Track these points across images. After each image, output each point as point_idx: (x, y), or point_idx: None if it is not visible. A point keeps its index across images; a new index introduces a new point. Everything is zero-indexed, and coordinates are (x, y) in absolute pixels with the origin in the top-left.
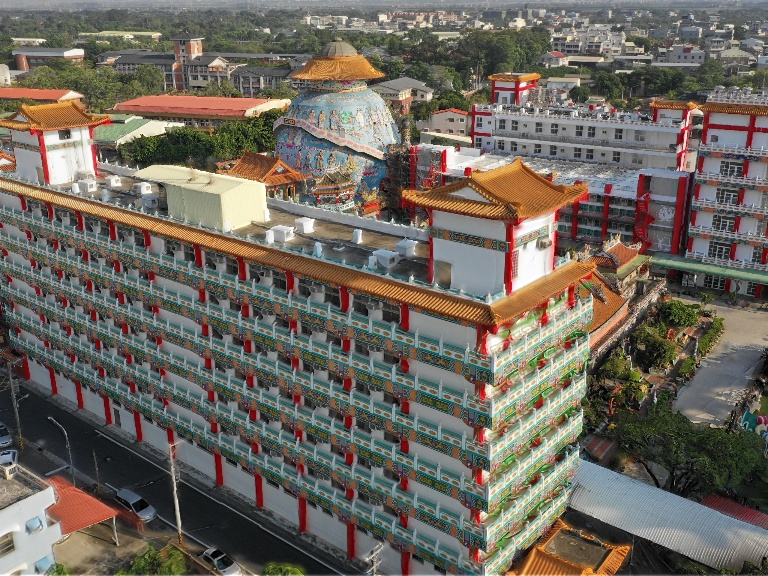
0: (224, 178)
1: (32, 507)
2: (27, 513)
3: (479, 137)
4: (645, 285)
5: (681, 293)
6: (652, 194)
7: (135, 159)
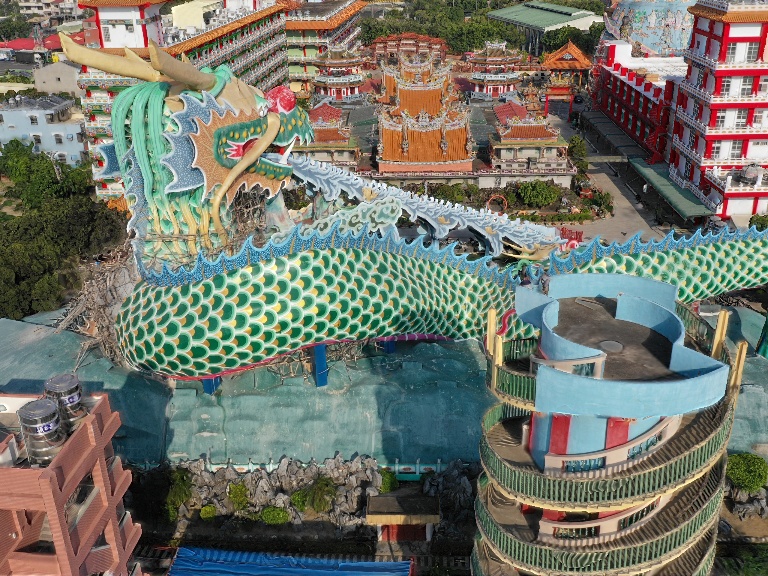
0: (193, 2)
1: (71, 129)
2: (69, 131)
3: None
4: (534, 163)
5: (641, 202)
6: None
7: (549, 44)
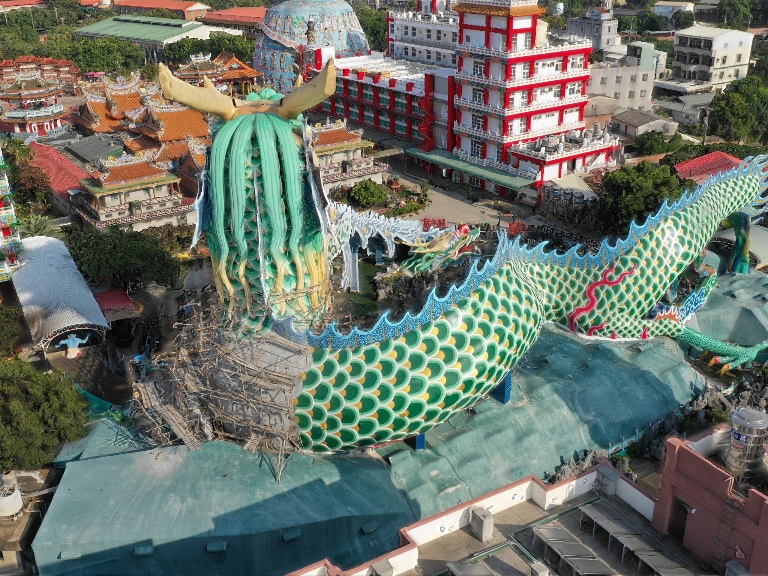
0: None
1: None
2: None
3: (392, 43)
4: (350, 166)
5: (438, 186)
6: (436, 93)
7: (174, 57)
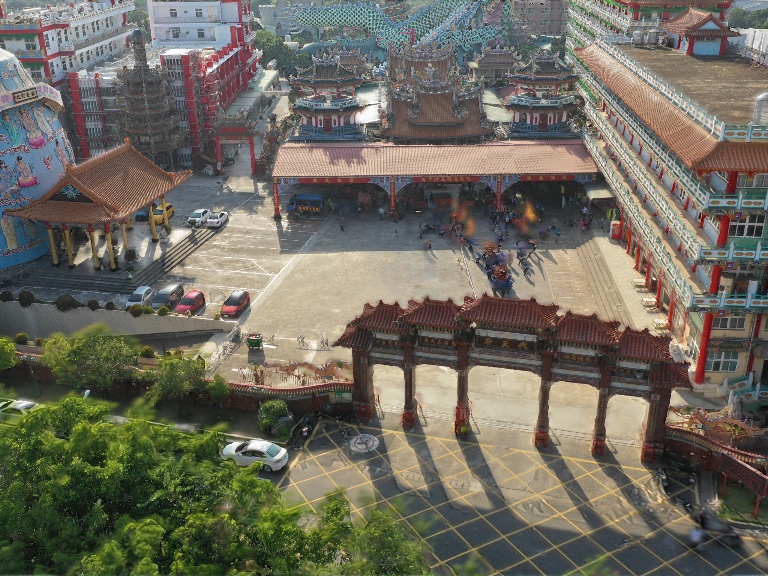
0: None
1: None
2: None
3: None
4: None
5: (271, 103)
6: None
7: None
